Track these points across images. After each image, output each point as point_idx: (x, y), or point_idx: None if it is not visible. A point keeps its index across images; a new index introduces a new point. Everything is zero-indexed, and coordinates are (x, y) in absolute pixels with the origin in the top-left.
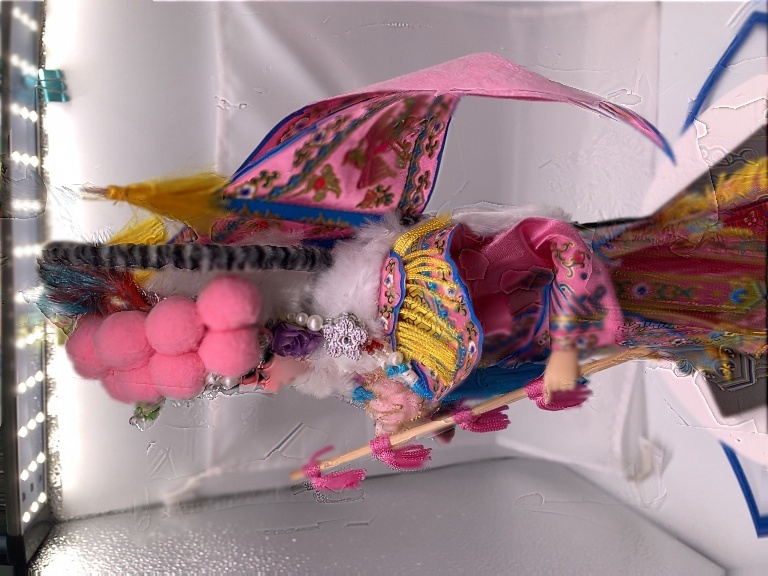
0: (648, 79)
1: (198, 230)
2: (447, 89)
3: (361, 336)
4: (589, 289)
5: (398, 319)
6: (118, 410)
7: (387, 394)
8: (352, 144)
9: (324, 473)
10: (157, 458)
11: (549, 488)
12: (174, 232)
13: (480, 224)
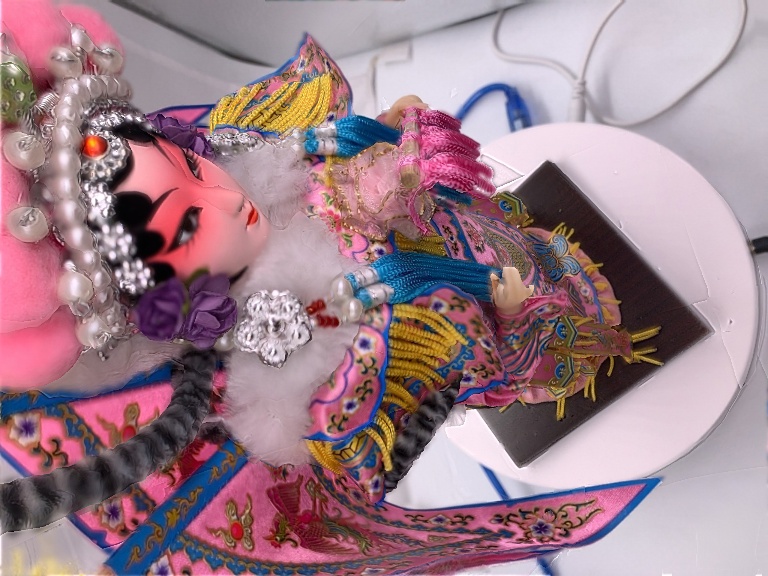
0: None
1: None
2: None
3: None
4: None
5: None
6: None
7: None
8: None
9: None
10: None
11: None
12: None
13: None
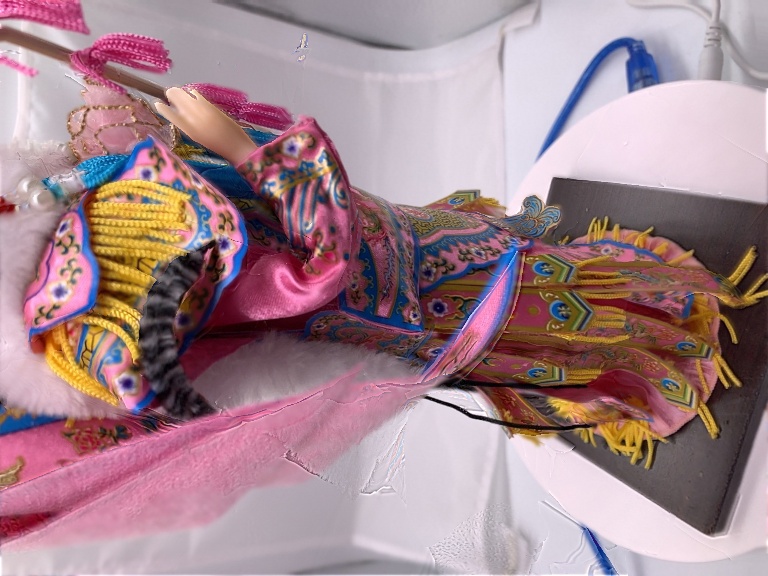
0: None
1: None
2: None
3: None
4: None
5: None
6: None
7: None
8: None
9: None
10: None
11: None
12: None
13: None
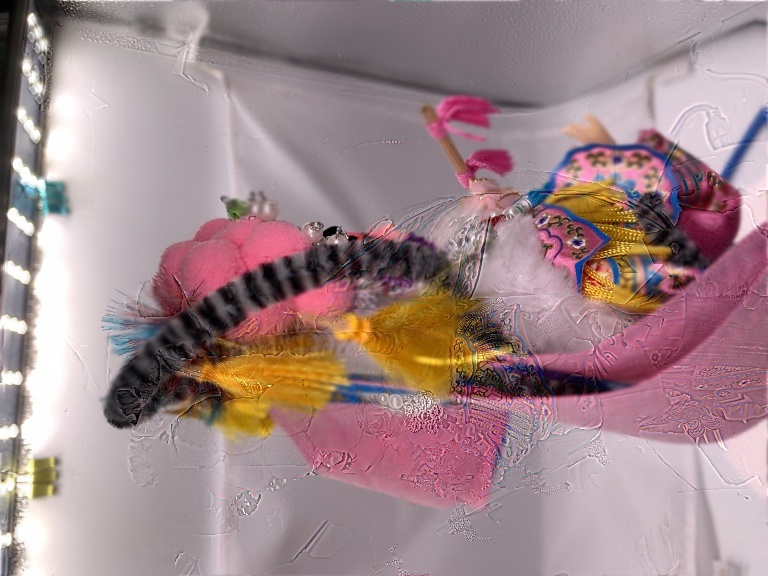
0: (606, 180)
1: (307, 320)
2: (507, 192)
3: (438, 410)
4: (684, 339)
5: (471, 392)
6: (224, 496)
7: (458, 466)
8: (421, 241)
9: (353, 571)
10: (185, 569)
11: (572, 567)
12: (268, 326)
13: (524, 305)
